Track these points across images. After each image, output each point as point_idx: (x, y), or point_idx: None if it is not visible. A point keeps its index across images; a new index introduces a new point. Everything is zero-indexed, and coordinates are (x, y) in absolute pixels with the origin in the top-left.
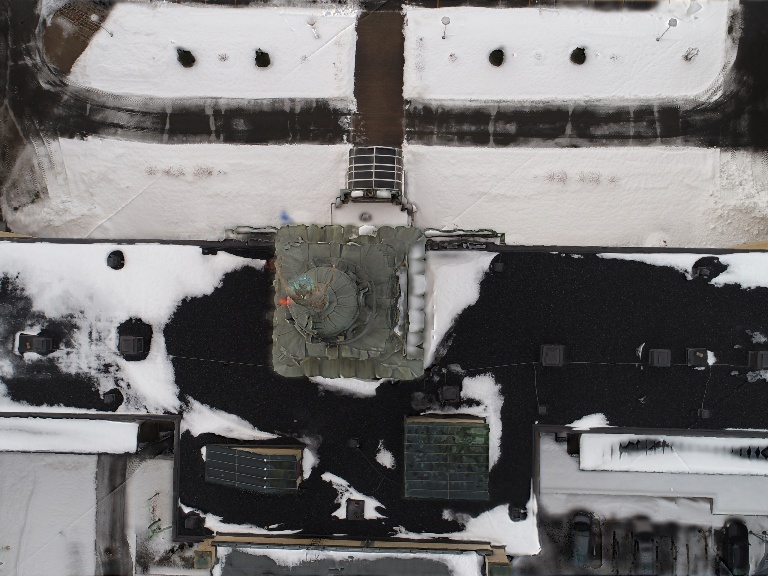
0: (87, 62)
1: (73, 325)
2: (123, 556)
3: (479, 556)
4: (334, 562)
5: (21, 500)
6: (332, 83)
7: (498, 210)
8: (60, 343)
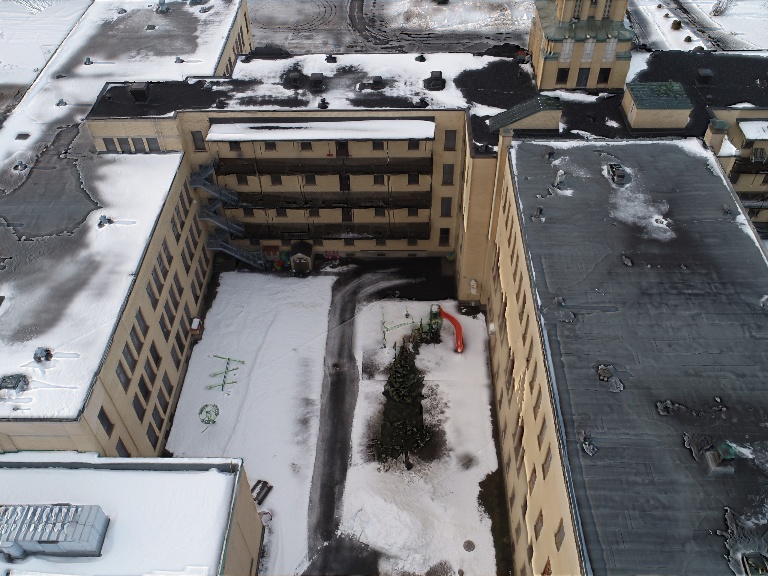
0: None
1: (394, 80)
2: (350, 369)
3: (698, 140)
4: (596, 147)
5: (262, 328)
6: None
7: None
8: (386, 86)
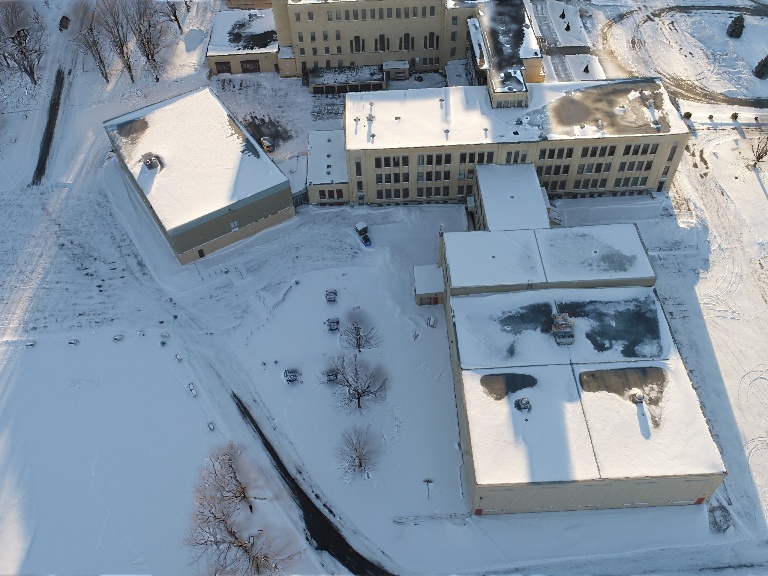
0: None
1: None
2: None
3: None
4: None
5: None
6: None
7: None
8: None
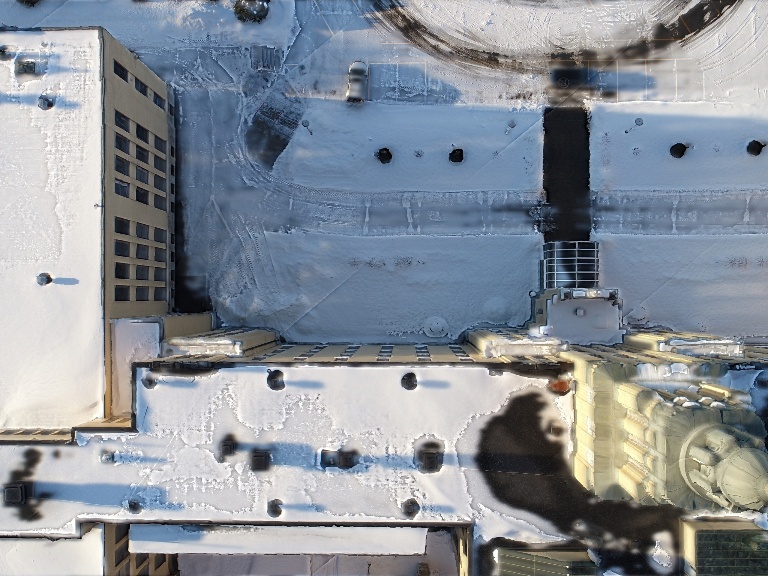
0: (290, 160)
1: (371, 441)
2: None
3: None
4: None
5: (240, 573)
6: (523, 176)
7: (682, 293)
8: (359, 458)
